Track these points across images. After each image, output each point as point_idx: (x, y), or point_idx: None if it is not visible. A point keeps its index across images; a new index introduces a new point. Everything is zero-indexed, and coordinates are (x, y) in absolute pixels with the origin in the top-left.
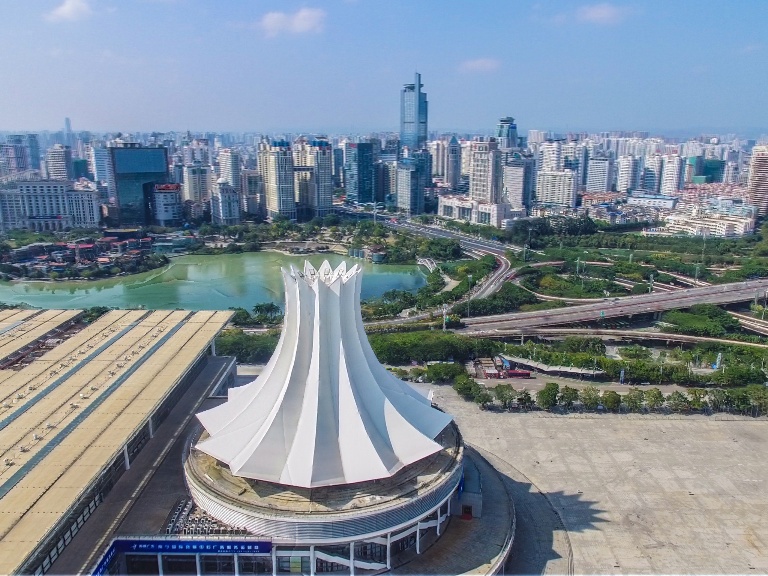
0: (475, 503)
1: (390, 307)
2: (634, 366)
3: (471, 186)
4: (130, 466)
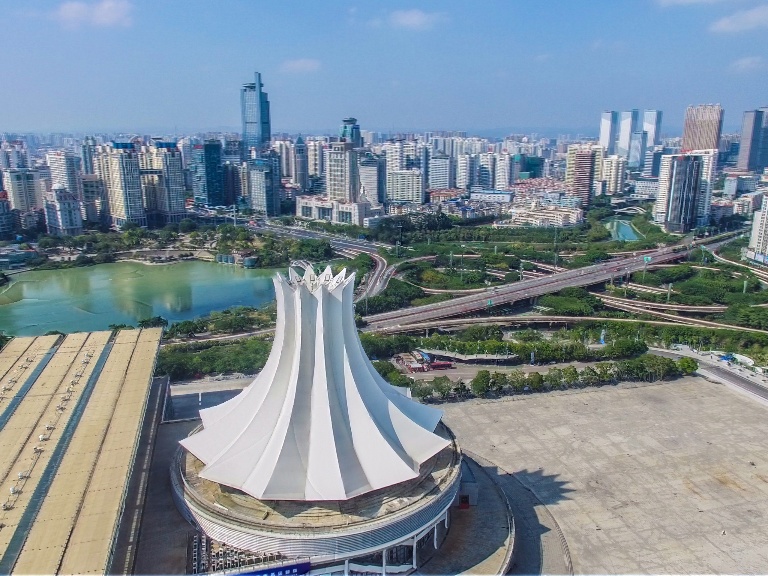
0: (472, 492)
1: None
2: (540, 348)
3: (329, 186)
4: None
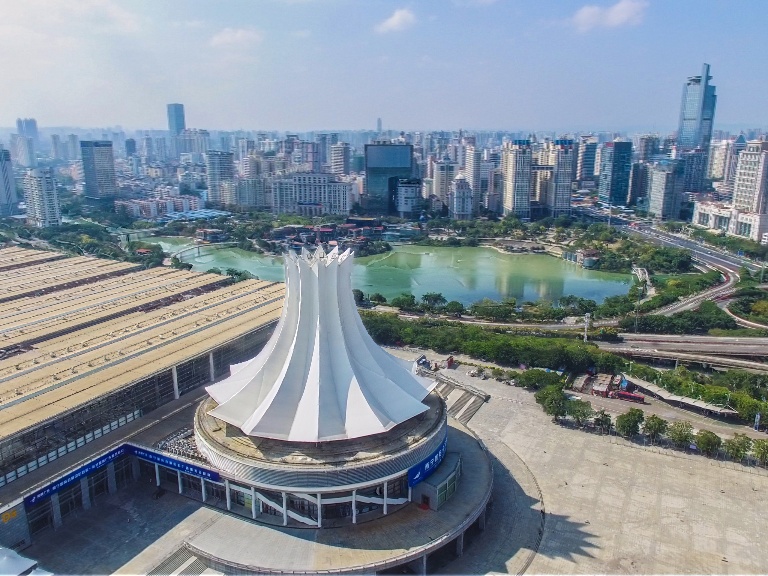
0: (432, 495)
1: (552, 311)
2: None
3: (735, 192)
4: (180, 397)
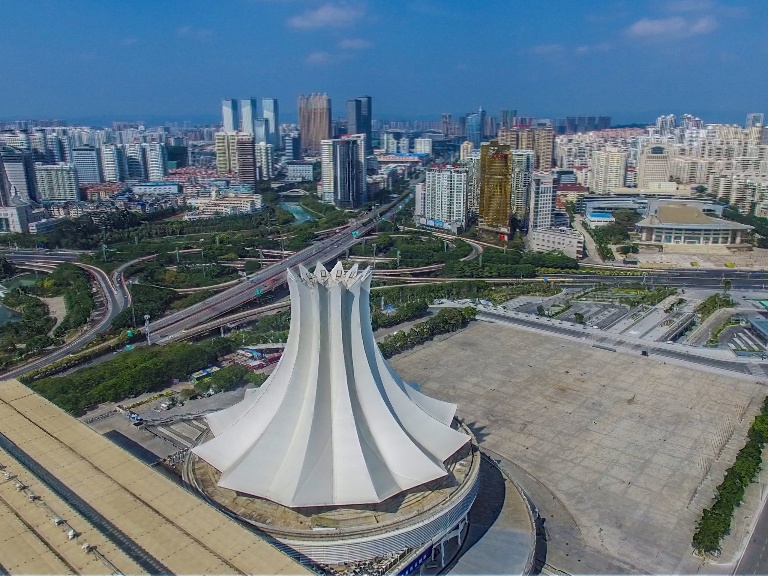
0: None
1: (38, 341)
2: None
3: None
4: None
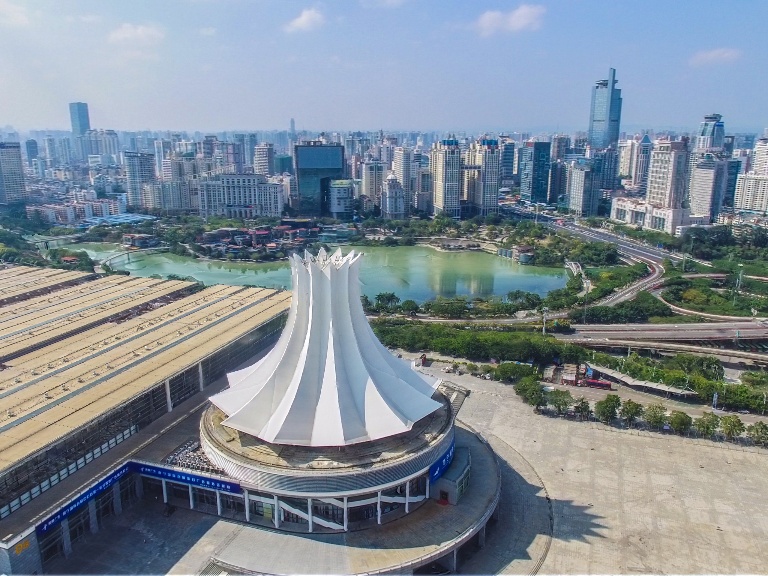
0: (451, 490)
1: (504, 306)
2: (733, 391)
3: (648, 189)
4: (173, 409)
